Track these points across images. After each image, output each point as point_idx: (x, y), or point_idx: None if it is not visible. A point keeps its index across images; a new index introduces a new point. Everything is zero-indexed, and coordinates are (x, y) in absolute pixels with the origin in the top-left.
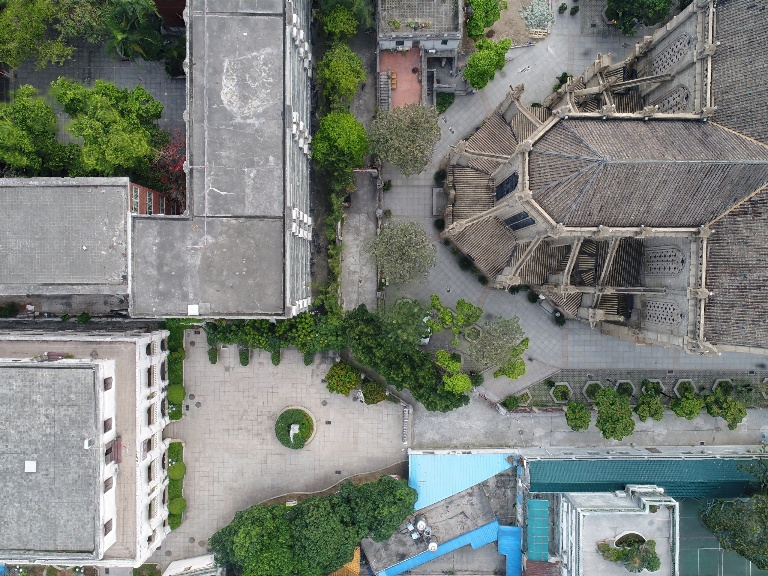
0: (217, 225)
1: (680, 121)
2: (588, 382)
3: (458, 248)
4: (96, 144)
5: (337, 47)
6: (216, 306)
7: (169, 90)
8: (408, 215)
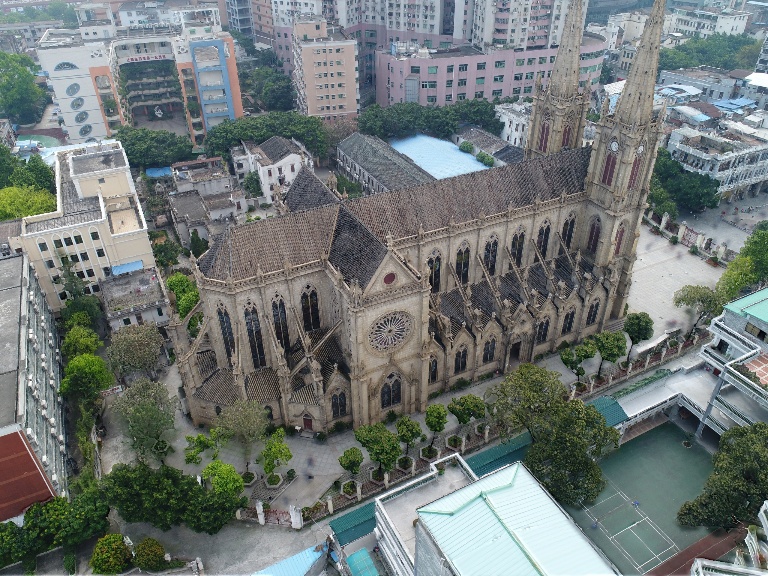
0: None
1: None
2: (371, 471)
3: (212, 425)
4: None
5: None
6: None
7: None
8: None
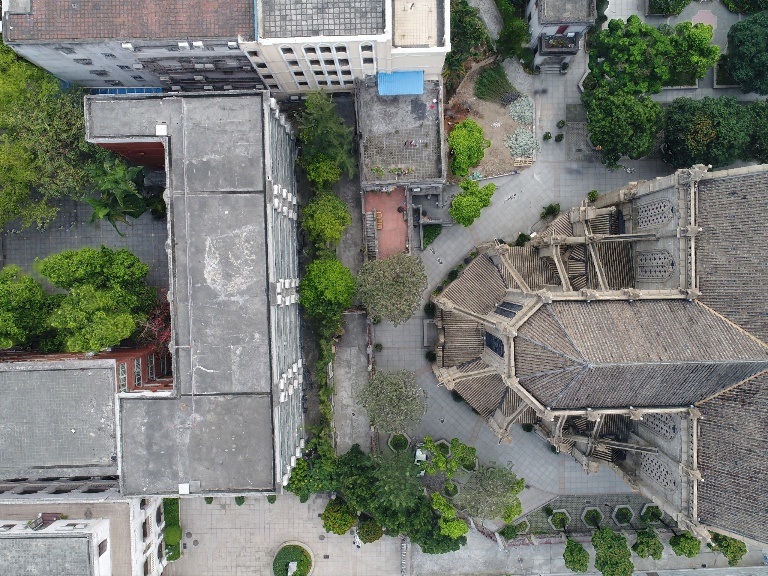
0: (205, 403)
1: (665, 300)
2: (586, 508)
3: None
4: (80, 334)
5: (321, 196)
6: (206, 484)
7: (156, 231)
8: (399, 347)
